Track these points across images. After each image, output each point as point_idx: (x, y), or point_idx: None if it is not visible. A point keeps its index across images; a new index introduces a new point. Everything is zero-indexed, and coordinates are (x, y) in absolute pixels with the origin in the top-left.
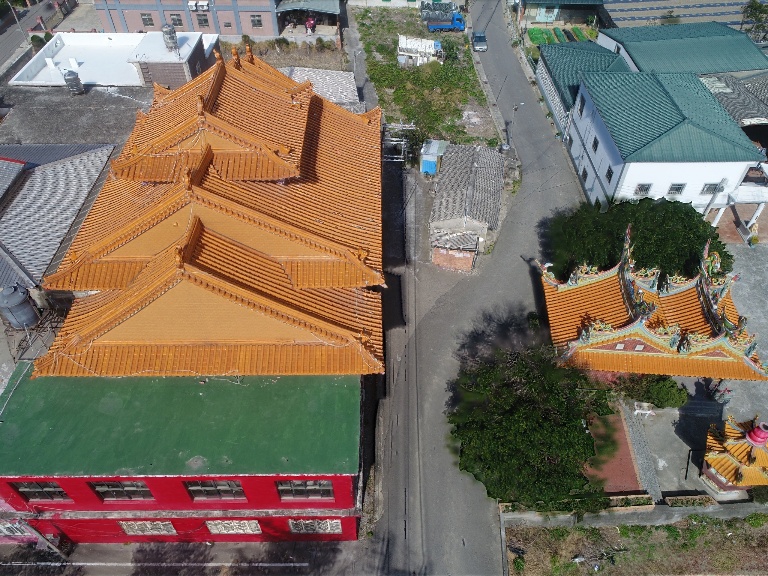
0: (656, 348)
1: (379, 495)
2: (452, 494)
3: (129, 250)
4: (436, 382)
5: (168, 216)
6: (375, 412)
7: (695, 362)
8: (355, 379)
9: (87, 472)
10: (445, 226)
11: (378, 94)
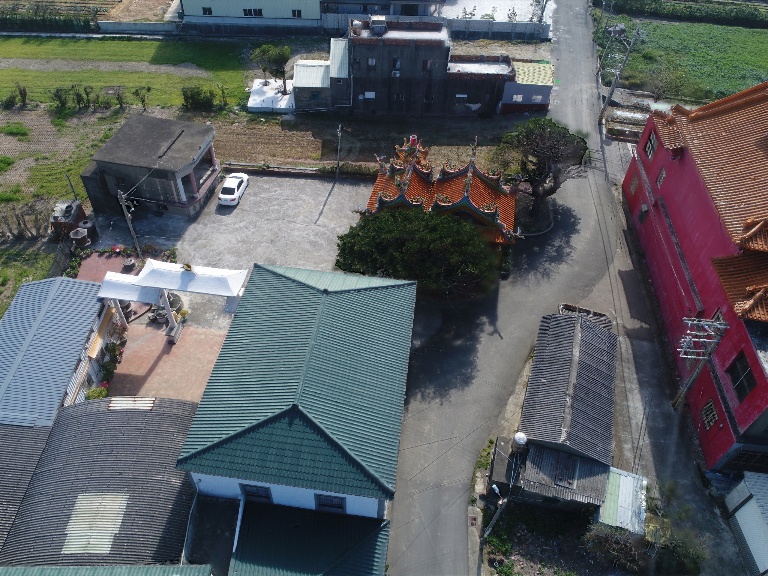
0: None
1: (615, 192)
2: (573, 189)
3: None
4: (588, 234)
5: None
6: None
7: None
8: None
9: None
10: None
11: None
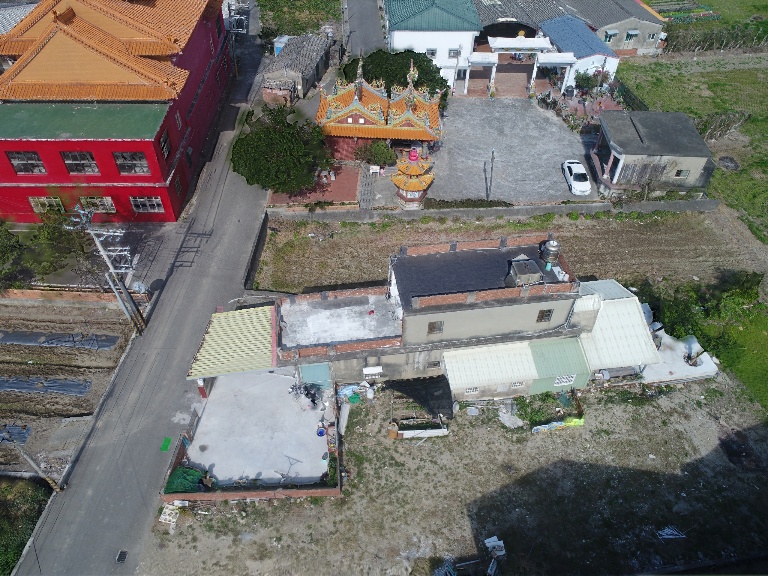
0: (372, 121)
1: (194, 202)
2: (239, 202)
3: (34, 32)
4: None
5: (54, 6)
6: (202, 168)
7: (397, 131)
8: (165, 108)
9: (4, 137)
10: (274, 77)
11: (261, 14)
